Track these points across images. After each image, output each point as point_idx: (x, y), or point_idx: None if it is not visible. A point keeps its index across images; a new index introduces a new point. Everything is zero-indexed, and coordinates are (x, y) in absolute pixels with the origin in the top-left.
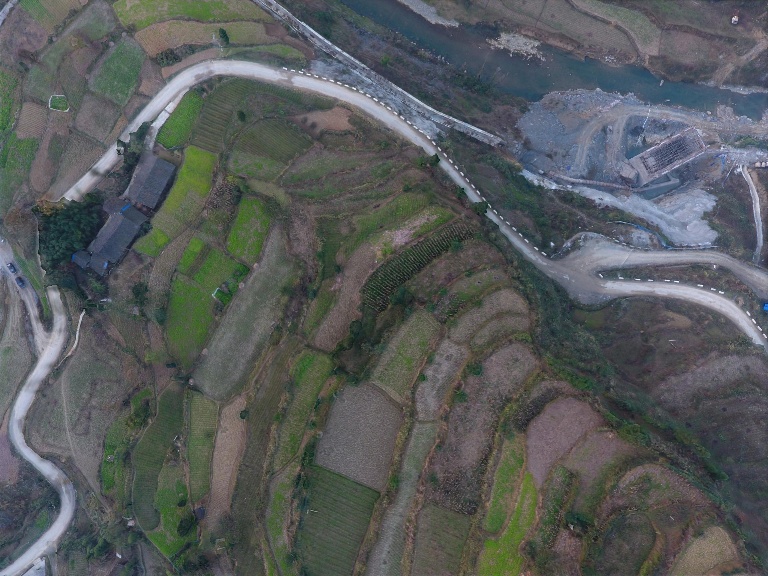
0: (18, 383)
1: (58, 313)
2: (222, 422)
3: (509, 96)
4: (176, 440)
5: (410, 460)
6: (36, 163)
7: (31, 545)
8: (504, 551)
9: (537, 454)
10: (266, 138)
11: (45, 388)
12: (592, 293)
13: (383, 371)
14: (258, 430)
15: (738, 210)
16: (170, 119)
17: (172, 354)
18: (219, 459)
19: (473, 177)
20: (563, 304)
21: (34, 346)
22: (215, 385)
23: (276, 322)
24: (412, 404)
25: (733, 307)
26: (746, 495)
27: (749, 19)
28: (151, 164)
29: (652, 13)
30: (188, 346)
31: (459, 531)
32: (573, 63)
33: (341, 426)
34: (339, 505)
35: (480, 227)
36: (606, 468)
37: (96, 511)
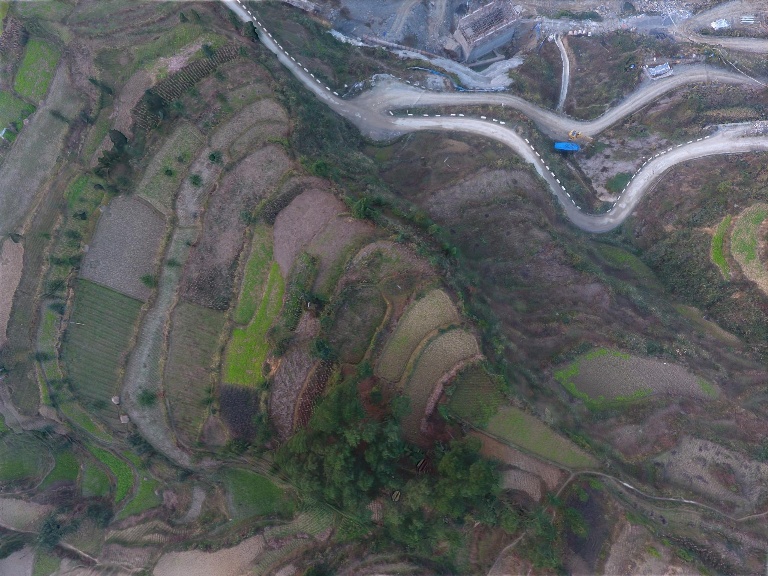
0: None
1: None
2: (3, 254)
3: None
4: None
5: (170, 265)
6: None
7: None
8: (251, 339)
9: (283, 244)
10: None
11: None
12: (383, 130)
13: (148, 184)
14: (35, 257)
15: (543, 68)
16: None
17: None
18: None
19: (276, 30)
20: (351, 137)
21: None
22: None
23: None
24: (173, 211)
25: (513, 136)
26: (501, 289)
27: None
28: None
29: None
30: None
31: (214, 327)
32: None
33: (108, 240)
34: (105, 317)
35: (250, 49)
36: (345, 250)
37: None
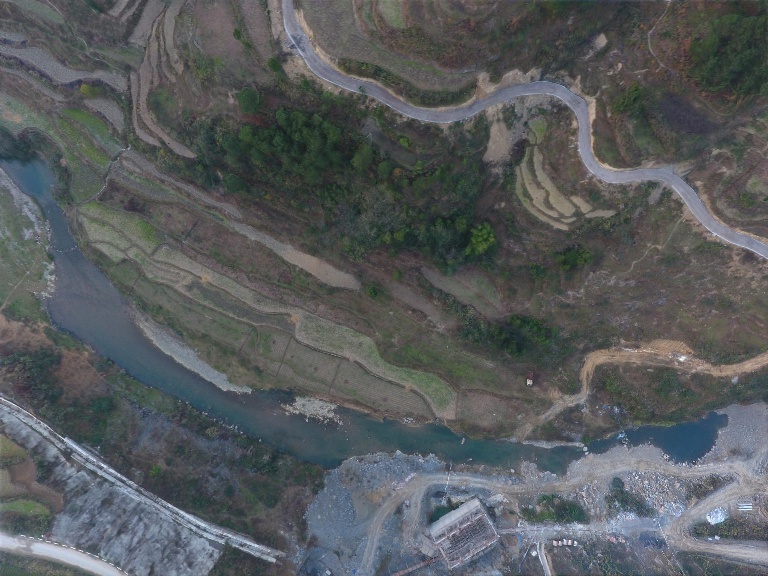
0: None
1: None
2: None
3: (305, 467)
4: None
5: None
6: None
7: None
8: None
9: None
10: None
11: None
12: None
13: None
14: None
15: None
16: None
17: None
18: None
19: None
20: None
21: None
22: None
23: None
24: None
25: None
26: None
27: (545, 379)
28: None
29: (446, 378)
30: None
31: None
32: (372, 424)
33: None
34: None
35: None
36: None
37: None
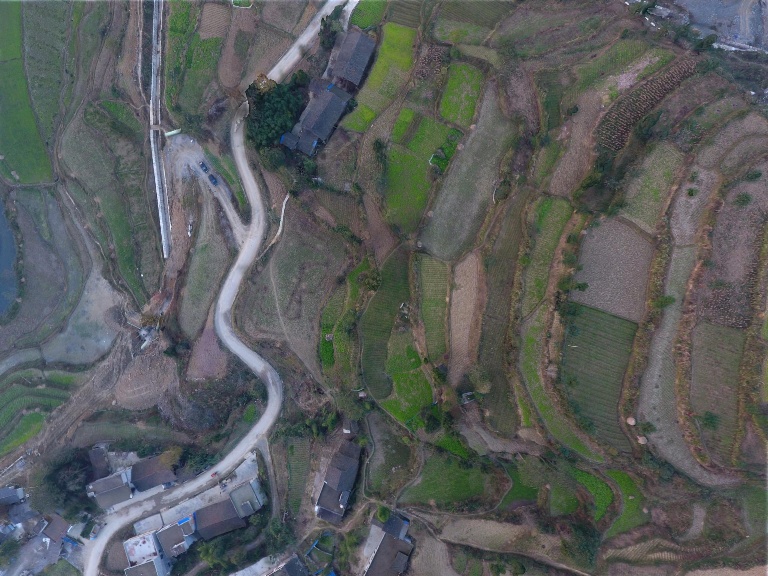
0: (221, 277)
1: (255, 205)
2: (456, 279)
3: None
4: (403, 307)
5: (672, 284)
6: (223, 60)
7: (241, 440)
8: None
9: None
10: (469, 5)
11: (254, 276)
12: None
13: (631, 204)
14: (498, 281)
15: None
16: (362, 1)
17: (393, 222)
18: (456, 316)
19: None
20: None
21: (234, 240)
22: (443, 246)
23: (498, 180)
24: (668, 230)
25: None
26: None
27: None
28: (355, 40)
29: None
30: (408, 213)
31: (734, 346)
32: None
33: (593, 262)
34: (598, 339)
35: None
36: None
37: (315, 393)
